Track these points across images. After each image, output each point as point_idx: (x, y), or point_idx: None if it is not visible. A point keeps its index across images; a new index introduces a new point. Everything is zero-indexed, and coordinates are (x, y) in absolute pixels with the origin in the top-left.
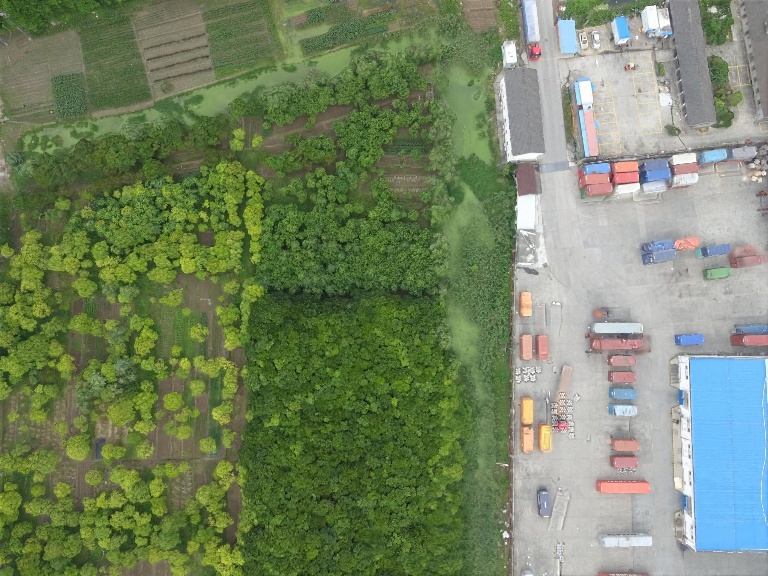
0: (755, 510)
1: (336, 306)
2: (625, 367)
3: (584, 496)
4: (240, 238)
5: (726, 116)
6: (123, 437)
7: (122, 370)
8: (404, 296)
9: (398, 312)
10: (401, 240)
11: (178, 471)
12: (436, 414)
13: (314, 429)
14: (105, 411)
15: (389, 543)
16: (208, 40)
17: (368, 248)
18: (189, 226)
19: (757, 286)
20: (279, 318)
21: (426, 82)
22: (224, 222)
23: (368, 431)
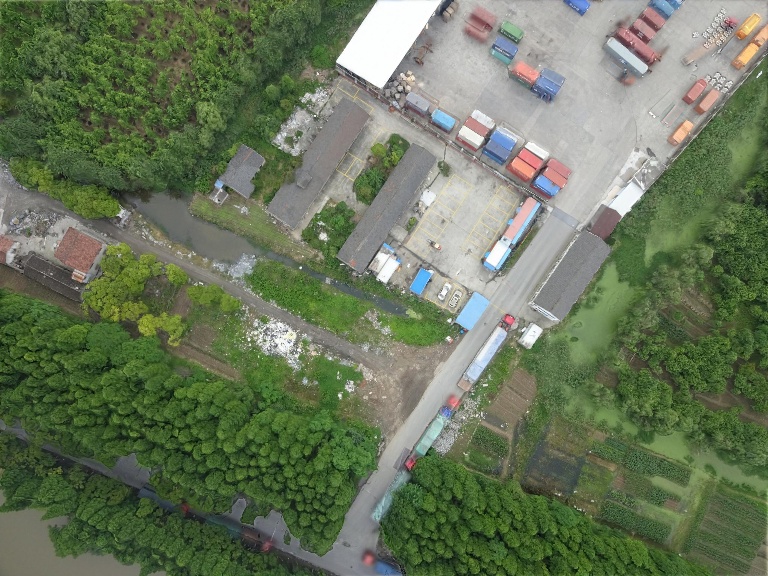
0: None
1: None
2: None
3: None
4: None
5: (397, 143)
6: None
7: None
8: None
9: None
10: (747, 258)
11: None
12: None
13: None
14: None
15: None
16: (760, 547)
17: None
18: None
19: None
20: None
21: (619, 368)
22: None
23: None
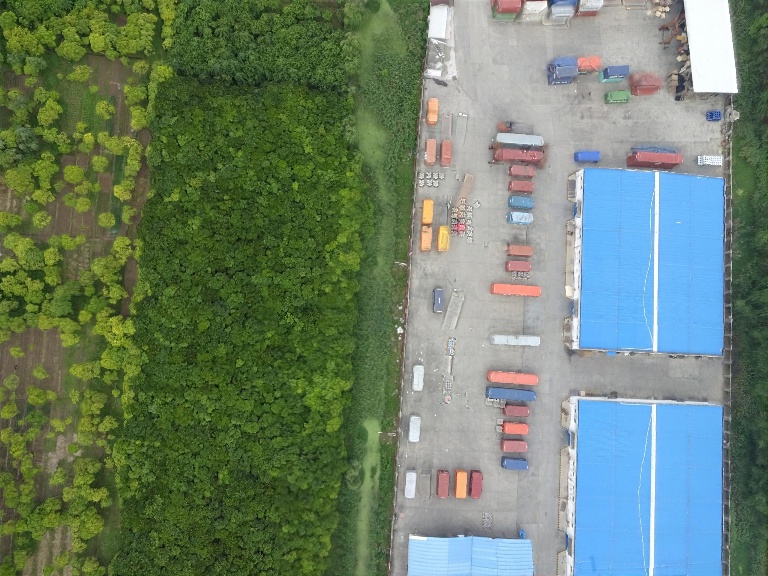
0: (637, 312)
1: (243, 90)
2: (524, 177)
3: (478, 298)
4: (152, 21)
5: None
6: (21, 211)
7: (22, 135)
8: (312, 89)
9: (305, 101)
10: (313, 36)
11: (75, 243)
12: (336, 201)
13: (213, 204)
14: (5, 184)
15: (282, 321)
16: None
17: (280, 41)
18: (101, 5)
19: (655, 114)
20: (185, 95)
21: None
22: (137, 3)
23: (267, 210)
